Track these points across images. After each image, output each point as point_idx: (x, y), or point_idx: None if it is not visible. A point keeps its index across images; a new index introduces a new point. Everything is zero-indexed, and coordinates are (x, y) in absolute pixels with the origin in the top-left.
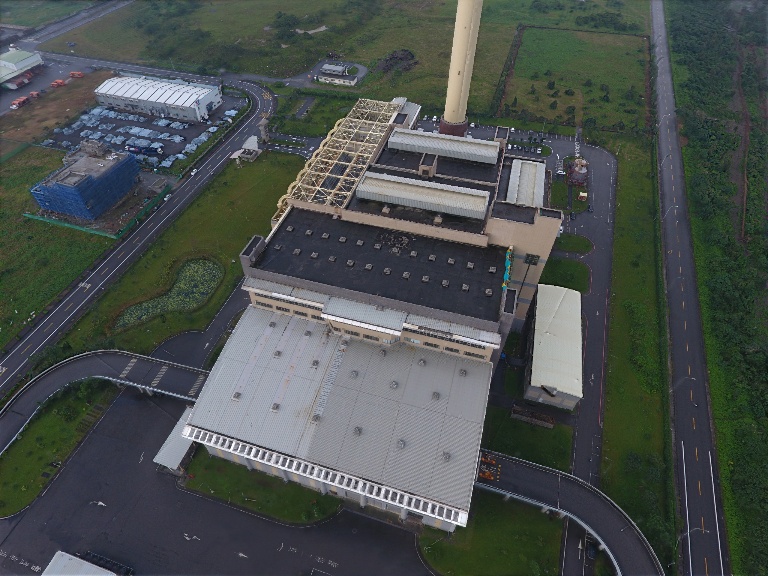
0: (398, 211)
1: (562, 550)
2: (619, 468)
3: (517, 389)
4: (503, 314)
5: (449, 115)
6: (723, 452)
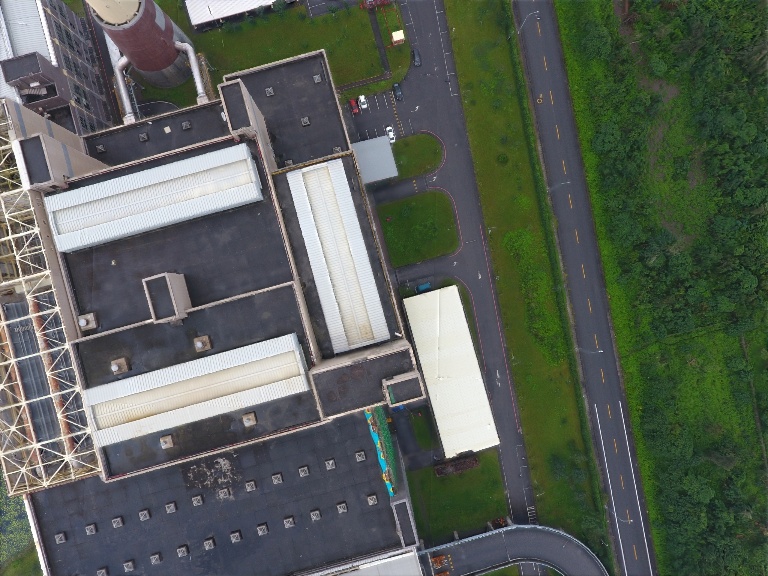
0: (184, 430)
1: (520, 571)
2: (547, 471)
3: (430, 437)
4: (405, 548)
5: (104, 13)
6: (632, 397)
